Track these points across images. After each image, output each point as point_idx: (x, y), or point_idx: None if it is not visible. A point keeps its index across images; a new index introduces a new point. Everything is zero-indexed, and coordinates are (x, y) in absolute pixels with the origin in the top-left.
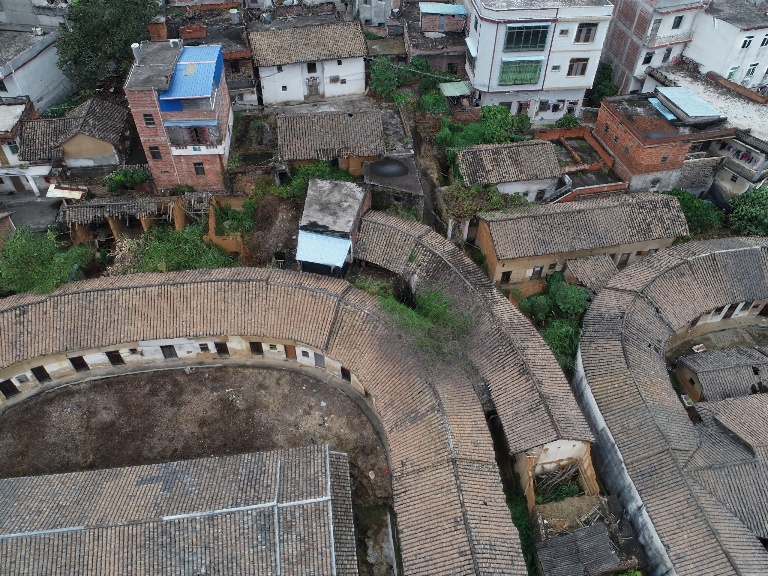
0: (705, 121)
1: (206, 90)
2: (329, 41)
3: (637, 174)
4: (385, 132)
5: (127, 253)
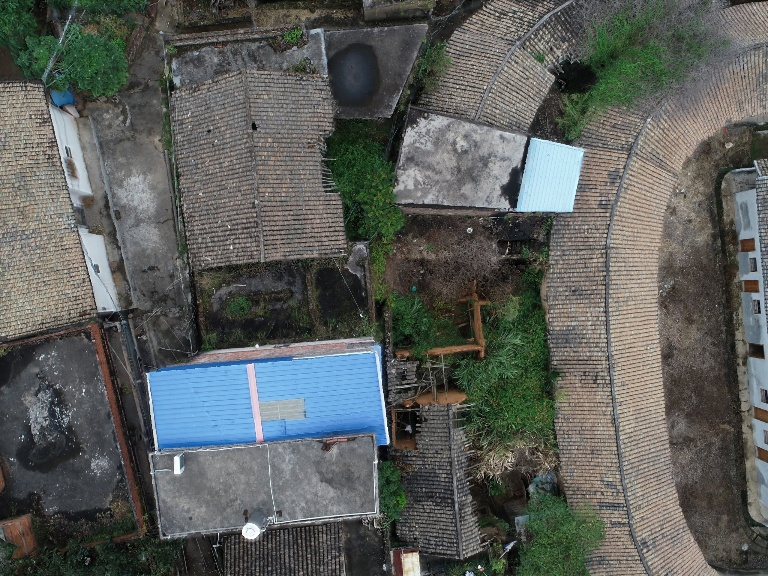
0: None
1: (357, 365)
2: (6, 162)
3: None
4: None
5: (527, 451)
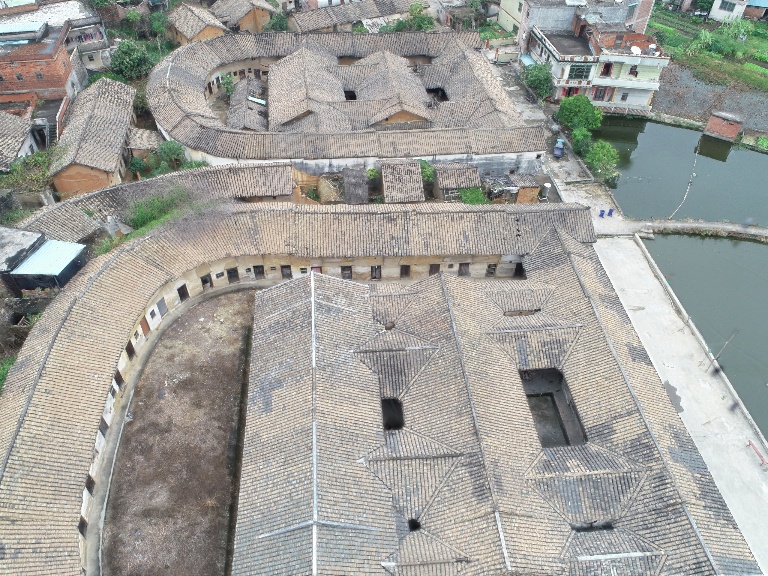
0: (43, 31)
1: None
2: None
3: (65, 85)
4: None
5: None
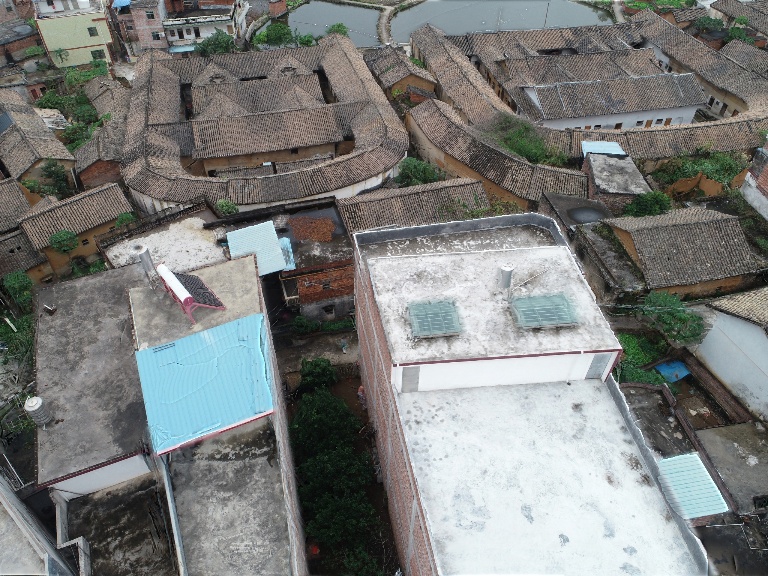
0: None
1: None
2: None
3: None
4: (616, 253)
5: None
